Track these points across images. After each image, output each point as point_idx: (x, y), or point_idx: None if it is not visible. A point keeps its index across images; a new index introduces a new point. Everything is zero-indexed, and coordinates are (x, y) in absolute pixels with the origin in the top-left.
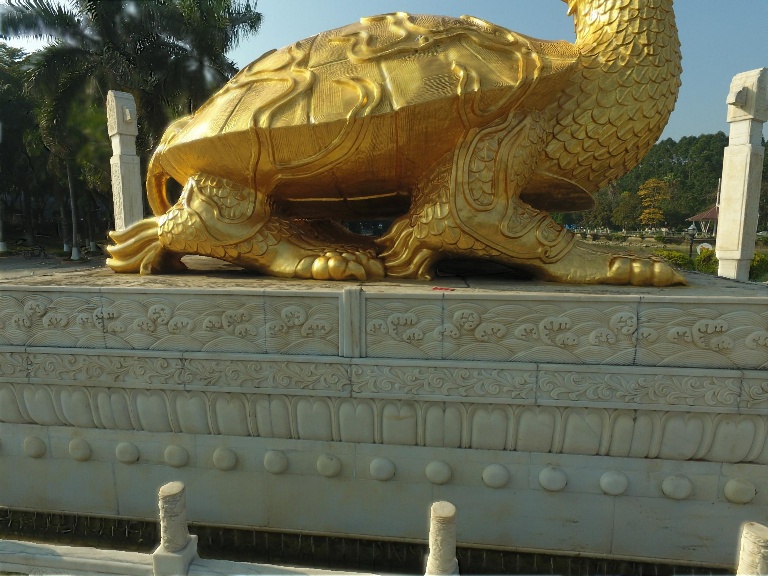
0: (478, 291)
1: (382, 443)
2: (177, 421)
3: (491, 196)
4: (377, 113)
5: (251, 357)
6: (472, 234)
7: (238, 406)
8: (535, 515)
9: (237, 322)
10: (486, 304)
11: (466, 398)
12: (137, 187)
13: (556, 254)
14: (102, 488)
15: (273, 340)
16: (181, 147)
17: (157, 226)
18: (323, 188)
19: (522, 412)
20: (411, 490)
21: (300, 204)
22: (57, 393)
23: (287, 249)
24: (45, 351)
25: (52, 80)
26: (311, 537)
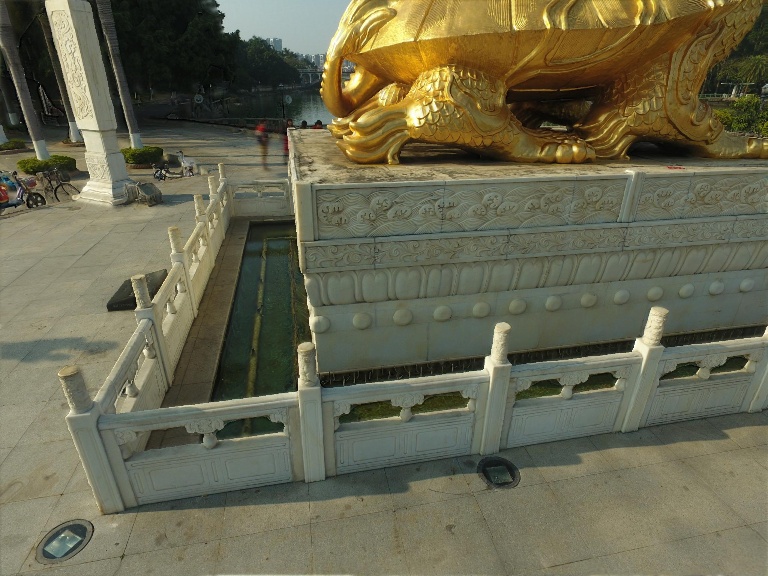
0: (701, 168)
1: (624, 280)
2: (488, 284)
3: (689, 92)
4: (657, 22)
5: (561, 229)
6: (675, 123)
7: (540, 266)
8: (700, 311)
9: (551, 203)
10: (716, 178)
11: (691, 243)
12: (95, 45)
13: (715, 137)
14: (417, 343)
15: (574, 214)
16: (459, 40)
17: (405, 117)
18: (559, 82)
19: (716, 248)
20: (635, 308)
21: (516, 94)
22: (395, 274)
23: (526, 137)
24: (393, 240)
25: None
26: (567, 349)
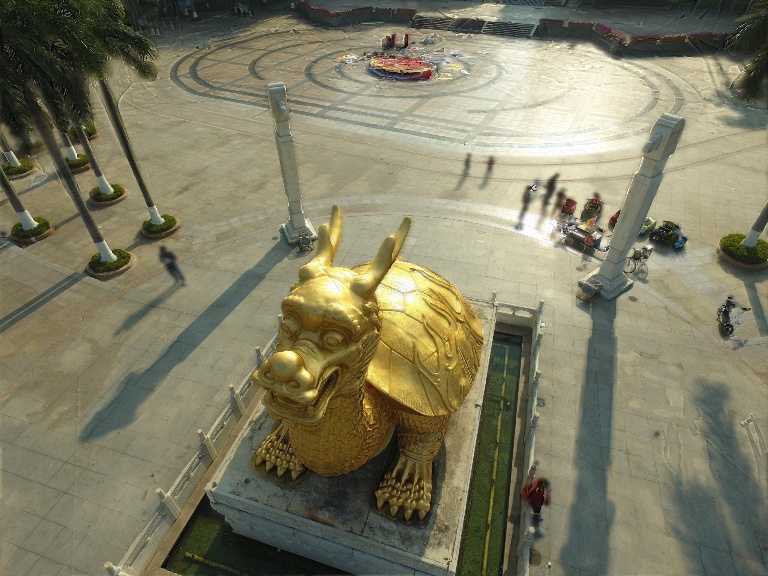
0: None
1: None
2: None
3: None
4: None
5: None
6: None
7: None
8: None
9: None
10: None
11: None
12: (637, 203)
13: None
14: None
15: None
16: None
17: None
18: None
19: None
20: None
21: None
22: None
23: None
24: None
25: (764, 32)
26: None
